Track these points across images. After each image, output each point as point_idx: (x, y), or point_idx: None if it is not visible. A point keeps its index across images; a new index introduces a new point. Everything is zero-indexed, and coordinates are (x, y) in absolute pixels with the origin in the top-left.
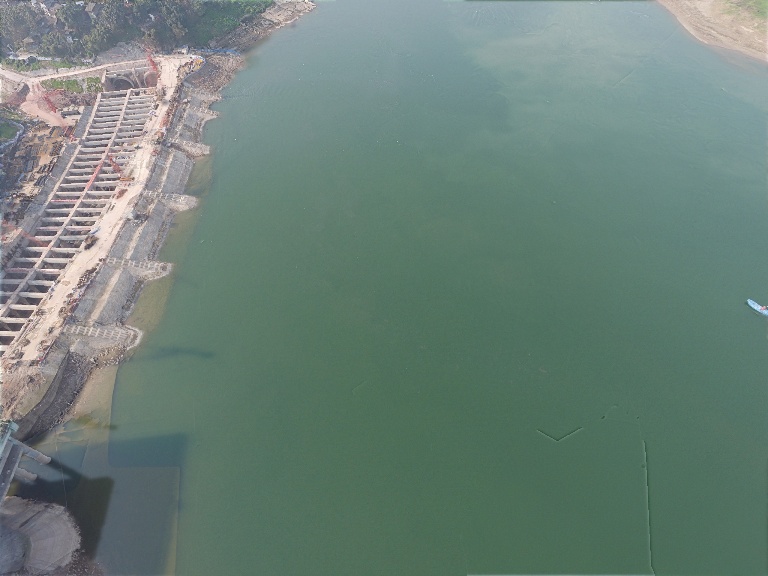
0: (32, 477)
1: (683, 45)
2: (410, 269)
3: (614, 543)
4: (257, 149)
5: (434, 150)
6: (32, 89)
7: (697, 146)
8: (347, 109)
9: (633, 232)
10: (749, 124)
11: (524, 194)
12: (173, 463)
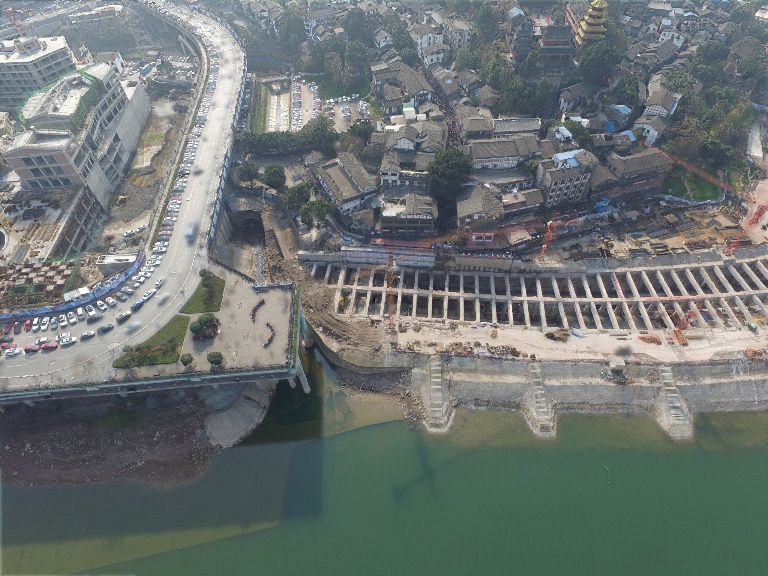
0: (292, 385)
1: None
2: None
3: None
4: None
5: None
6: None
7: None
8: None
9: None
10: None
11: None
12: (284, 516)
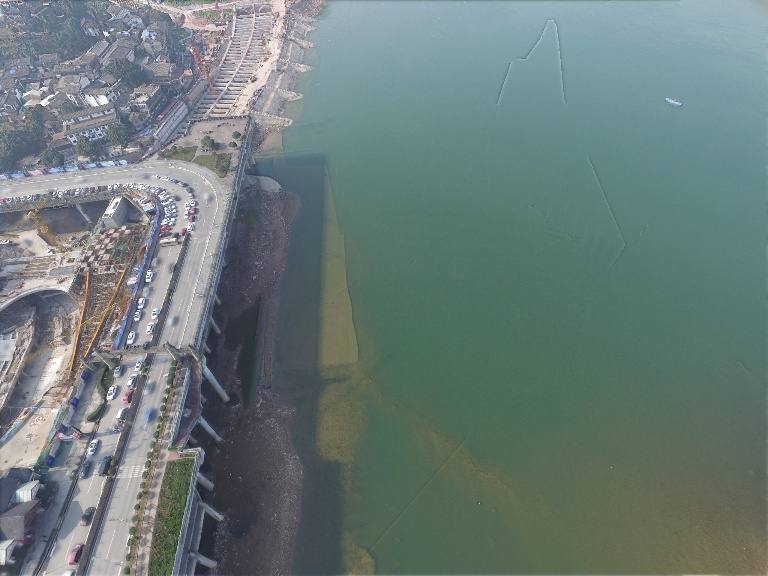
0: (249, 167)
1: None
2: (452, 94)
3: (550, 97)
4: (345, 44)
5: (466, 41)
6: (187, 17)
7: (653, 35)
8: (404, 22)
9: None
10: (694, 22)
11: None
12: (323, 164)
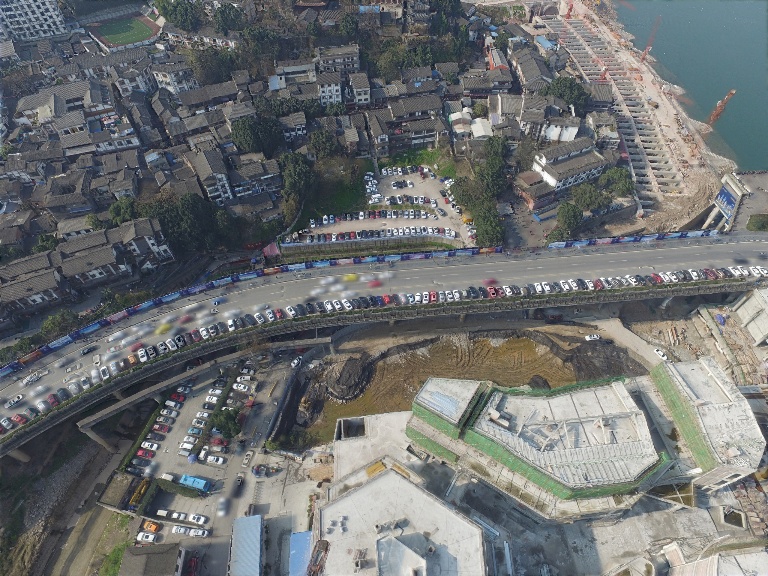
0: None
1: None
2: None
3: None
4: (691, 60)
5: None
6: None
7: None
8: (738, 36)
9: None
10: None
11: None
12: None
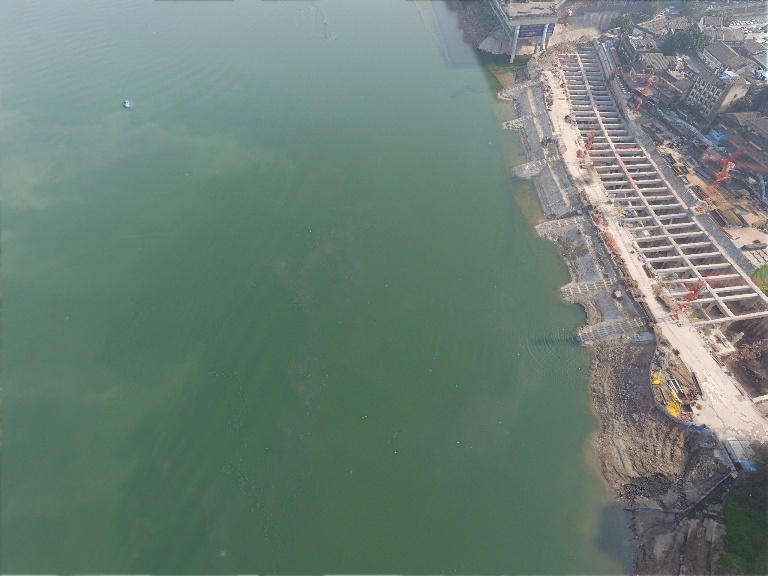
0: None
1: None
2: (329, 130)
3: None
4: (480, 234)
5: (271, 227)
6: None
7: None
8: (369, 298)
9: (148, 151)
10: None
11: (208, 182)
12: None
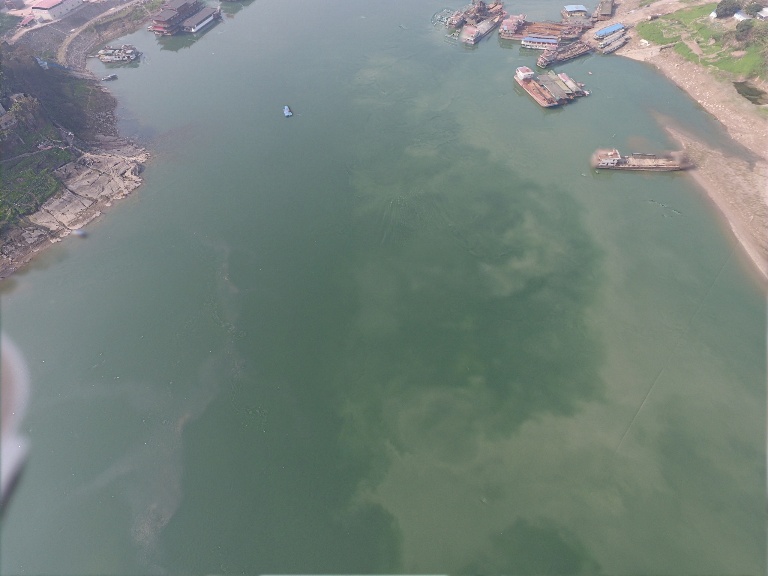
0: None
1: (747, 299)
2: None
3: None
4: None
5: None
6: None
7: None
8: (56, 538)
9: None
10: None
11: None
12: None
